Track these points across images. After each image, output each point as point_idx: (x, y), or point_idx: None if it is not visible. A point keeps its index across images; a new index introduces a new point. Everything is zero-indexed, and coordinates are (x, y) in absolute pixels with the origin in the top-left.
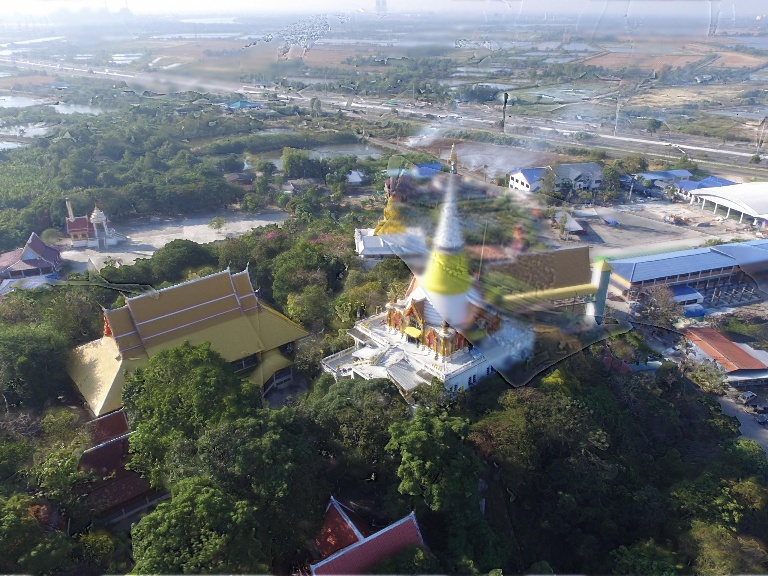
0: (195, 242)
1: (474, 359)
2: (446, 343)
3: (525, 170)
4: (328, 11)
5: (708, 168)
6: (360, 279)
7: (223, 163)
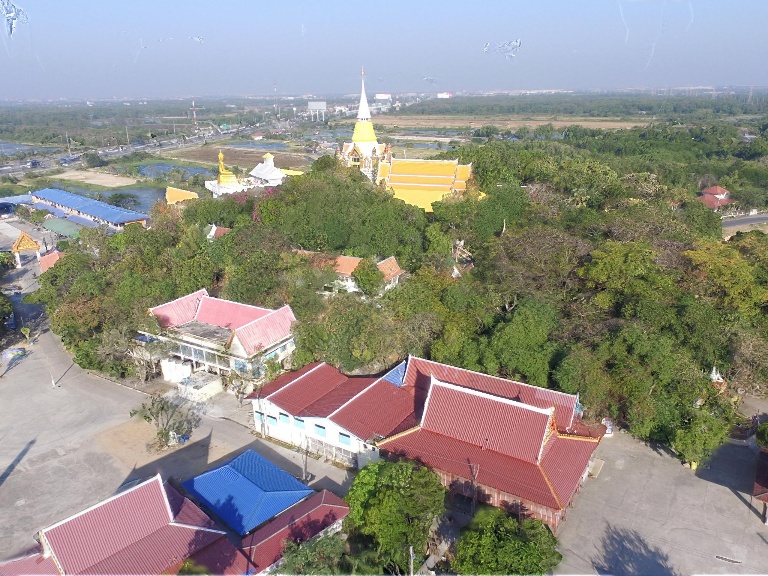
0: None
1: None
2: None
3: None
4: None
5: None
6: None
7: None
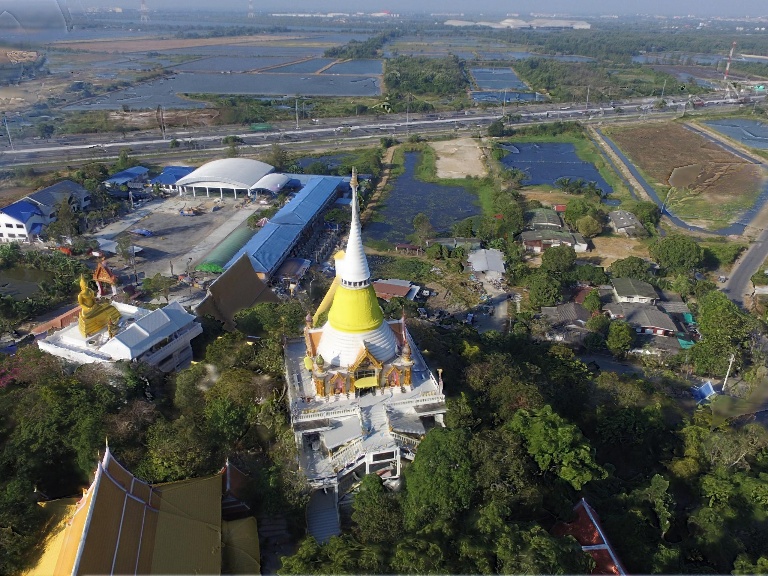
0: None
1: (423, 372)
2: None
3: (5, 209)
4: None
5: (144, 161)
6: (196, 380)
7: None
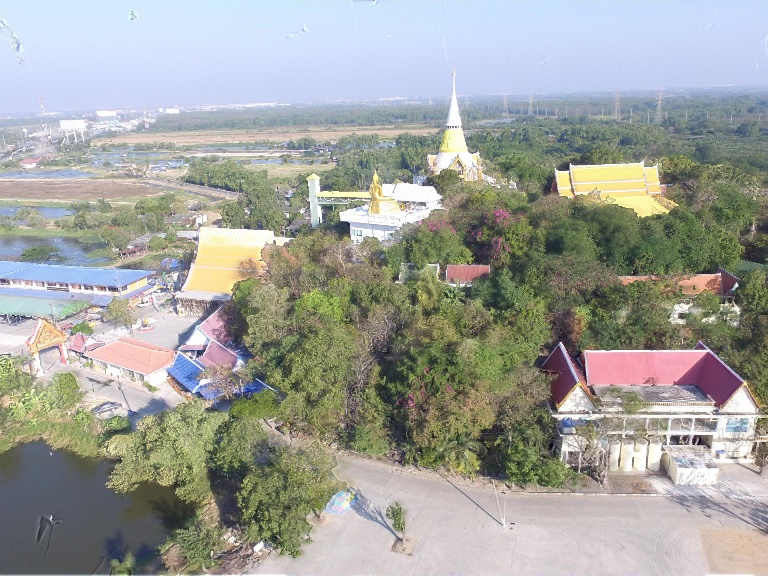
0: None
1: None
2: None
3: None
4: None
5: None
6: None
7: None
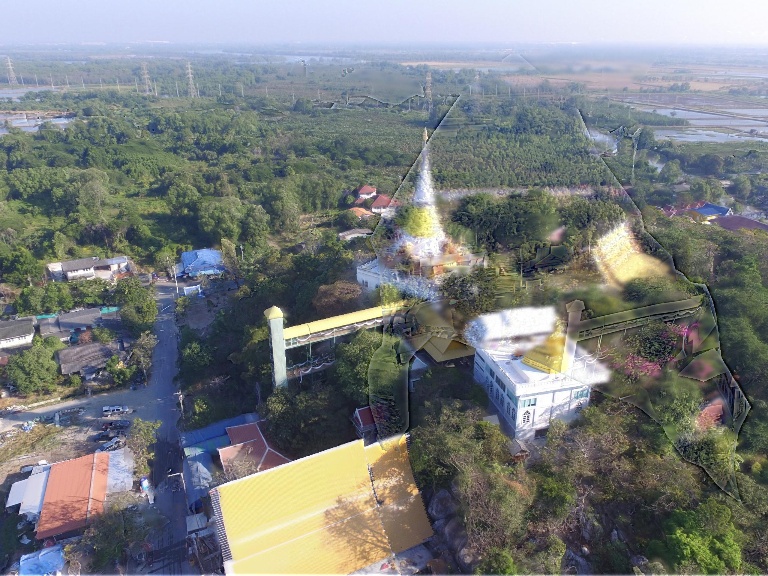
0: (734, 303)
1: None
2: None
3: None
4: None
5: None
6: None
7: None
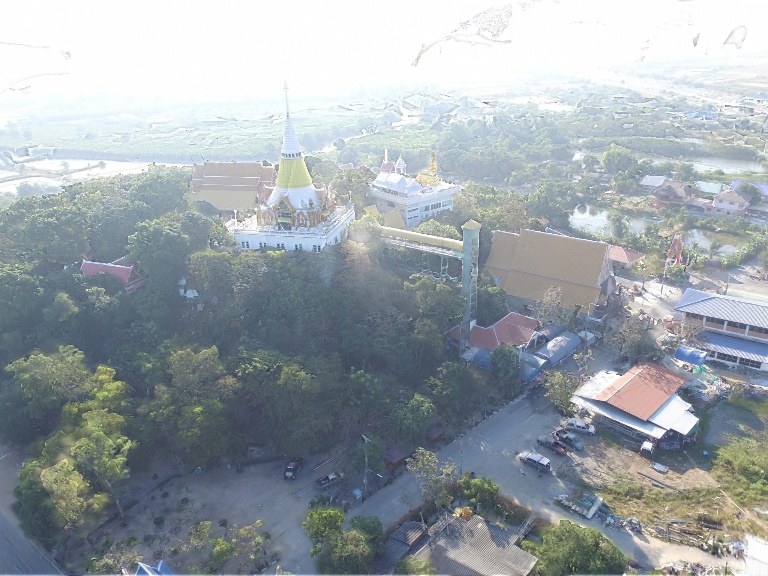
0: None
1: None
2: (258, 215)
3: None
4: (514, 1)
5: None
6: None
7: (555, 151)
